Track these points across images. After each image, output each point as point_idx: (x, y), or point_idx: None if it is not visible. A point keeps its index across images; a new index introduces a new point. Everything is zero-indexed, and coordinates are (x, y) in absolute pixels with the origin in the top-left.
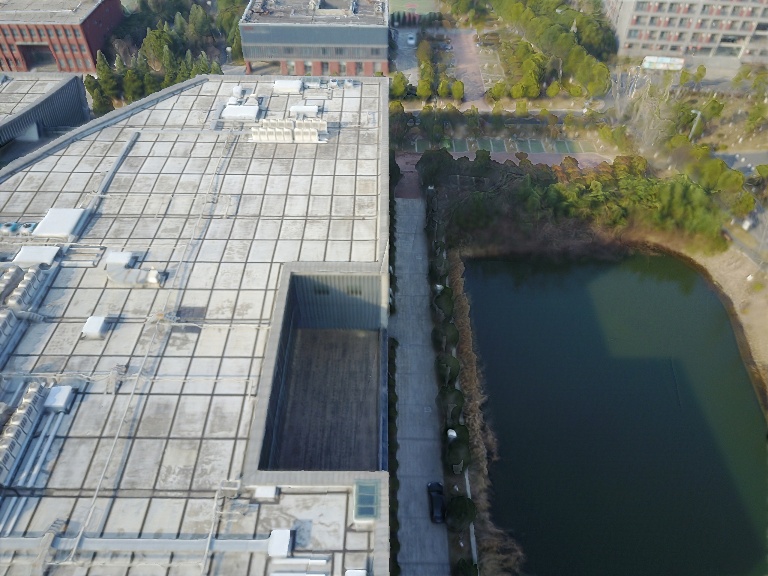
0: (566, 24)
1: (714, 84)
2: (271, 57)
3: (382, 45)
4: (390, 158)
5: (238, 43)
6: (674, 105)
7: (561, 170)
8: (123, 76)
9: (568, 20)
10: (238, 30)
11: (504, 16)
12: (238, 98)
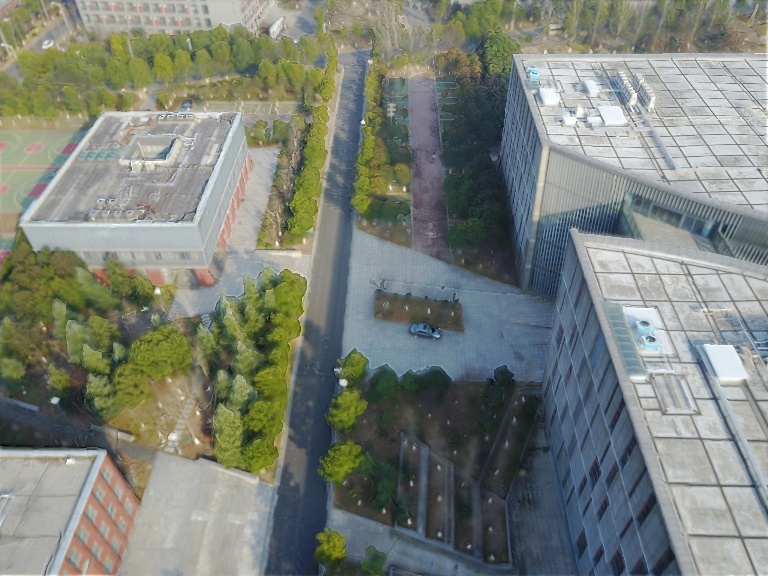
0: (210, 44)
1: (305, 21)
2: (216, 237)
3: (244, 136)
4: (477, 144)
5: (146, 279)
6: (360, 32)
7: (470, 78)
8: (258, 394)
9: (207, 40)
10: (120, 270)
11: (145, 79)
12: (577, 123)
